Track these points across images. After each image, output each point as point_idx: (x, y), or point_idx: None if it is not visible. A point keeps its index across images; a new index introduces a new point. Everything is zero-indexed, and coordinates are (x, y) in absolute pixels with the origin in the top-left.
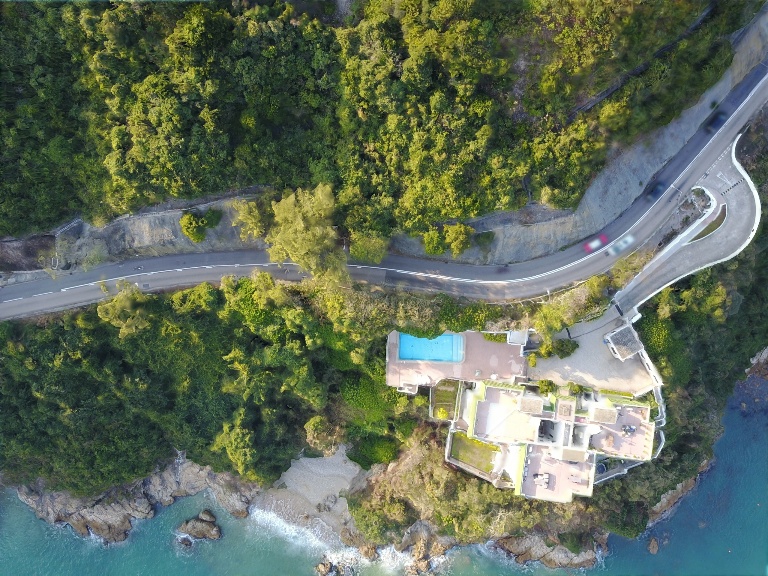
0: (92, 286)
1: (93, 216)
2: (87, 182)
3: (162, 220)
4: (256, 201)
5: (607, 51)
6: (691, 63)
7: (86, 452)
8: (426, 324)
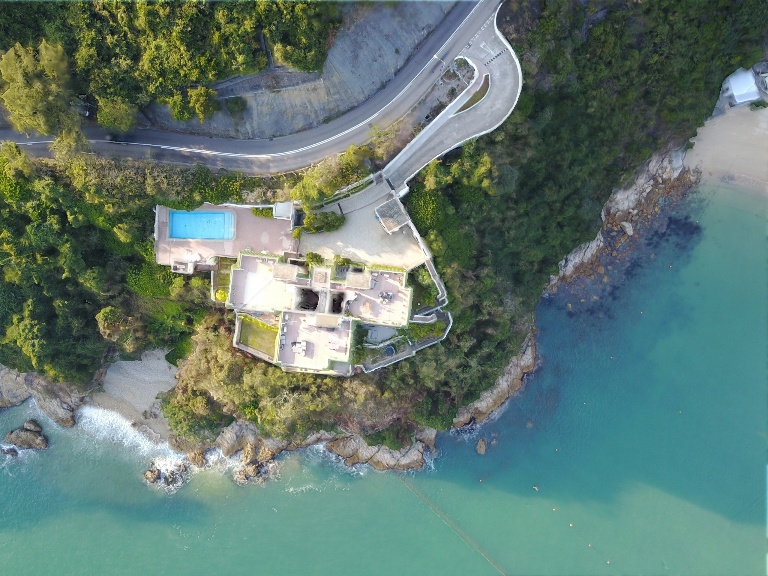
0: None
1: None
2: None
3: None
4: None
5: None
6: None
7: None
8: (180, 194)
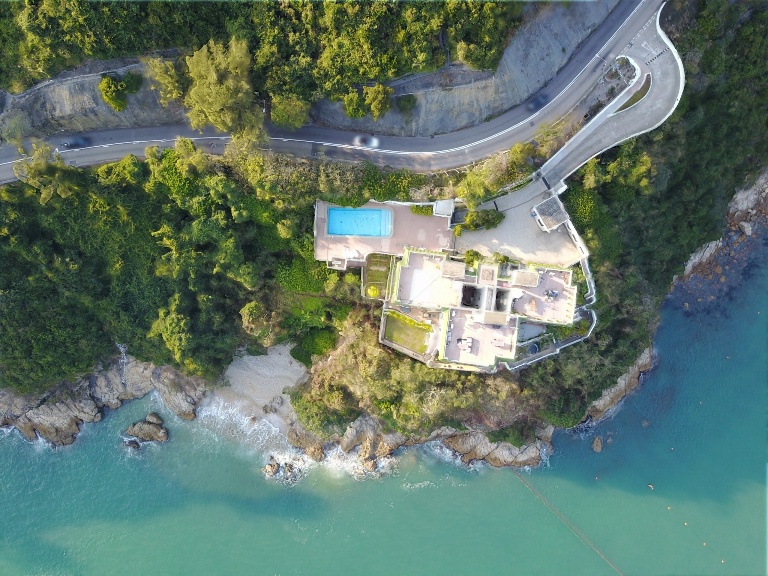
0: (19, 163)
1: (13, 84)
2: (4, 46)
3: (81, 86)
4: (175, 64)
5: None
6: None
7: (23, 340)
8: (349, 191)
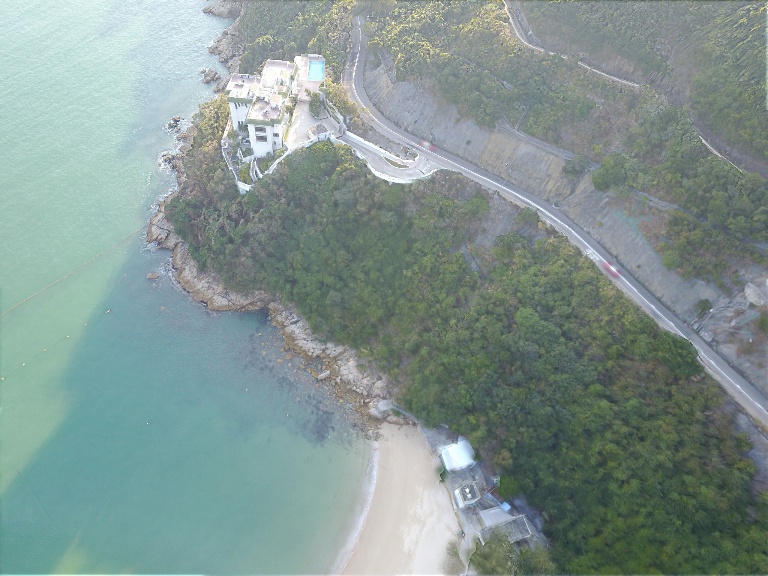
0: None
1: None
2: None
3: None
4: None
5: None
6: (480, 88)
7: (265, 4)
8: None
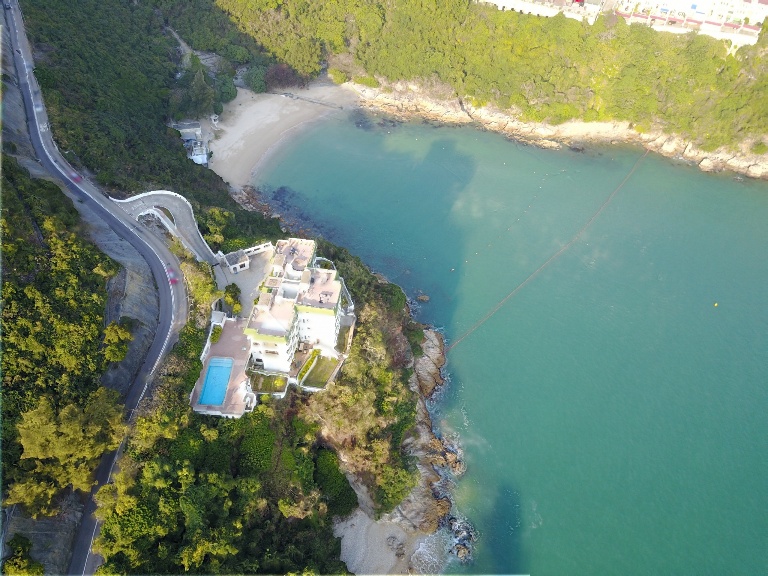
0: None
1: None
2: None
3: None
4: None
5: (1, 212)
6: None
7: None
8: (187, 367)
